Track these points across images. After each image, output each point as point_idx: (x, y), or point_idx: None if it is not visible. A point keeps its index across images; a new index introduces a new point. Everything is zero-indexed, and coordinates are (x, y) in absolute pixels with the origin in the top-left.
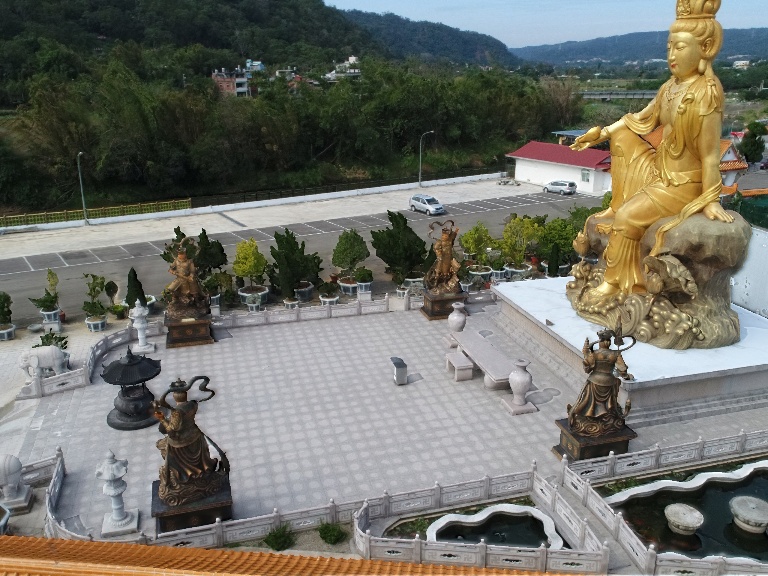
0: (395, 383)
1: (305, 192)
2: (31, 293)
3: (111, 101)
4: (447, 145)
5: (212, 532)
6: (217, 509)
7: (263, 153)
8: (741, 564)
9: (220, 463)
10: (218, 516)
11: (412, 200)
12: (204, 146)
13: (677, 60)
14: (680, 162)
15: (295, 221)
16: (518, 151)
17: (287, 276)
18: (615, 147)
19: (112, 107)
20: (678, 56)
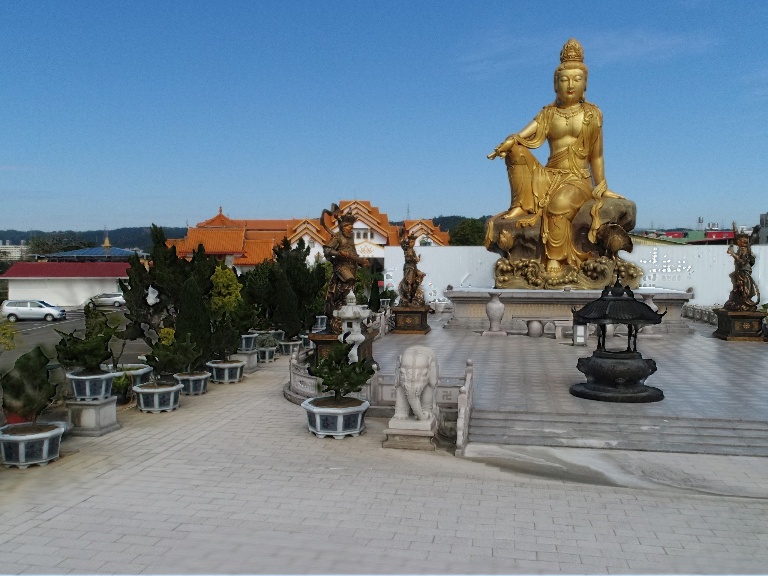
0: (581, 345)
1: None
2: None
3: None
4: None
5: None
6: None
7: None
8: None
9: None
10: None
11: (8, 307)
12: None
13: (575, 88)
14: (585, 161)
15: None
16: (9, 272)
17: None
18: (520, 157)
19: None
20: (576, 85)
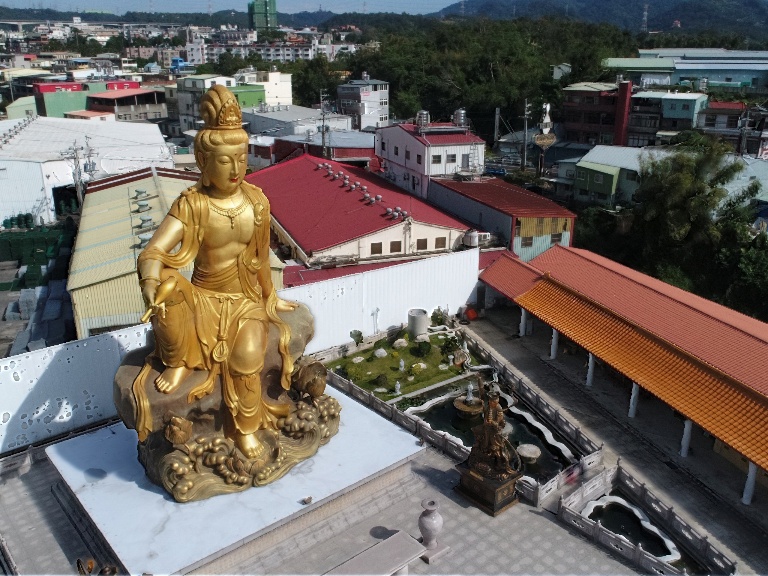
0: None
1: None
2: None
3: None
4: None
5: None
6: None
7: None
8: None
9: None
10: None
11: None
12: None
13: None
14: None
15: None
16: None
17: None
18: None
19: None
20: None
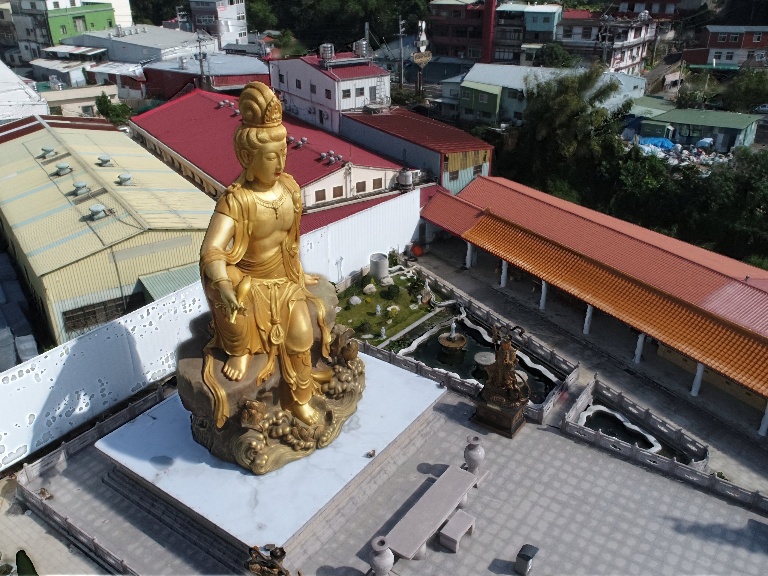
0: (530, 572)
1: None
2: None
3: None
4: None
5: None
6: None
7: None
8: (548, 348)
9: None
10: None
11: None
12: None
13: None
14: None
15: None
16: None
17: None
18: None
19: None
20: None
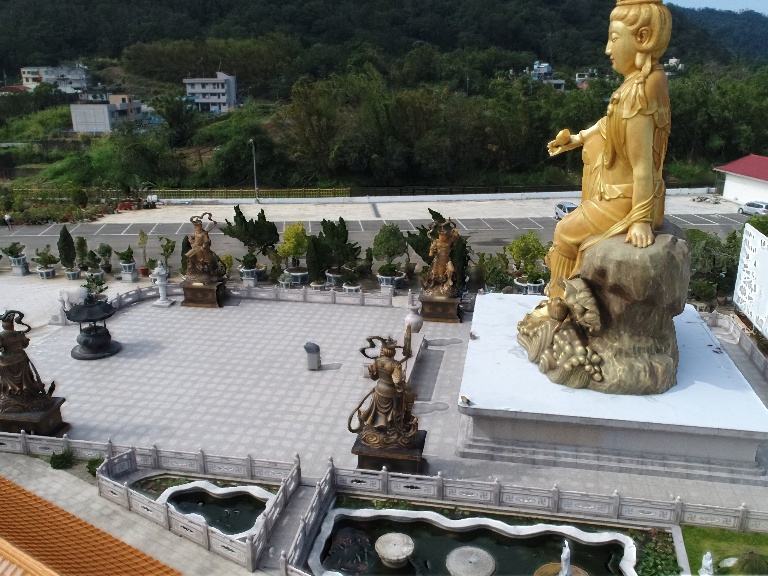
0: None
1: (464, 191)
2: (154, 250)
3: (354, 98)
4: (706, 156)
5: (18, 440)
6: (30, 423)
7: (486, 153)
8: None
9: (49, 389)
10: (32, 430)
11: (557, 207)
12: (427, 143)
13: (613, 54)
14: (613, 173)
15: (429, 217)
16: (730, 165)
17: (312, 260)
18: (583, 153)
19: (355, 104)
20: (613, 49)
